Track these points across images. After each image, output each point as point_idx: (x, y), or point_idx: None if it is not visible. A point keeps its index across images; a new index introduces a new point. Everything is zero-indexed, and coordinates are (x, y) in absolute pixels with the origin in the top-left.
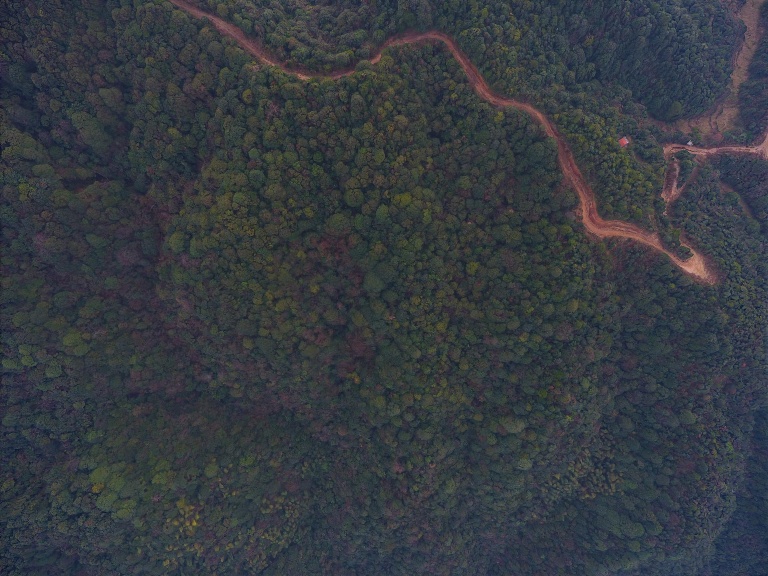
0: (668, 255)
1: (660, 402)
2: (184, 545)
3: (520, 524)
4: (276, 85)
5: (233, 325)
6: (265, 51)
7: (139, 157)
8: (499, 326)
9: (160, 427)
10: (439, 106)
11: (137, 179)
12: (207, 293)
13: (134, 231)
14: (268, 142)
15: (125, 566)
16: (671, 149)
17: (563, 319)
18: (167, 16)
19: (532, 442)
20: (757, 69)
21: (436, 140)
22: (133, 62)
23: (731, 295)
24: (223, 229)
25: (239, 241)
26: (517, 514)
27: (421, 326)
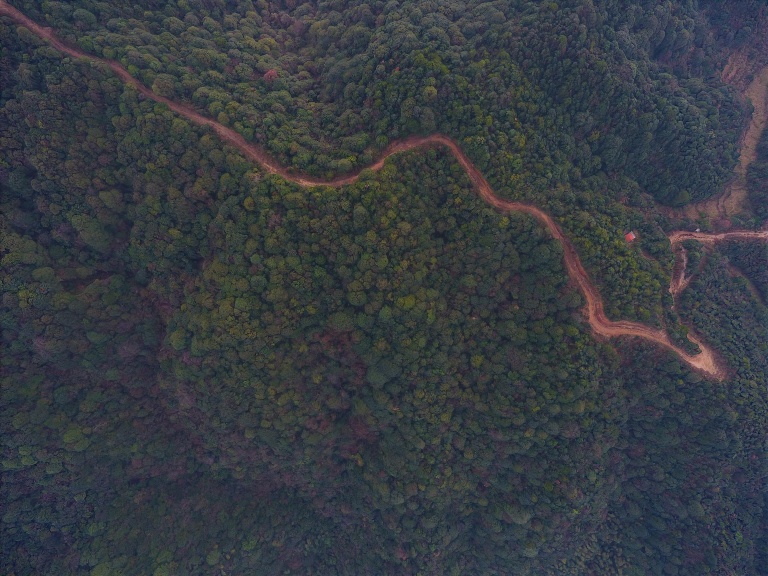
0: (676, 353)
1: (668, 491)
2: None
3: None
4: (278, 195)
5: (235, 418)
6: (267, 156)
7: (140, 253)
8: (504, 421)
9: (162, 514)
10: (443, 208)
11: (138, 272)
12: (209, 389)
13: (135, 324)
14: (270, 249)
15: None
16: (678, 237)
17: (569, 419)
18: (167, 125)
19: (538, 532)
20: (765, 150)
21: (440, 241)
22: (133, 166)
23: (740, 392)
24: (224, 333)
25: (241, 343)
26: None
27: (425, 418)
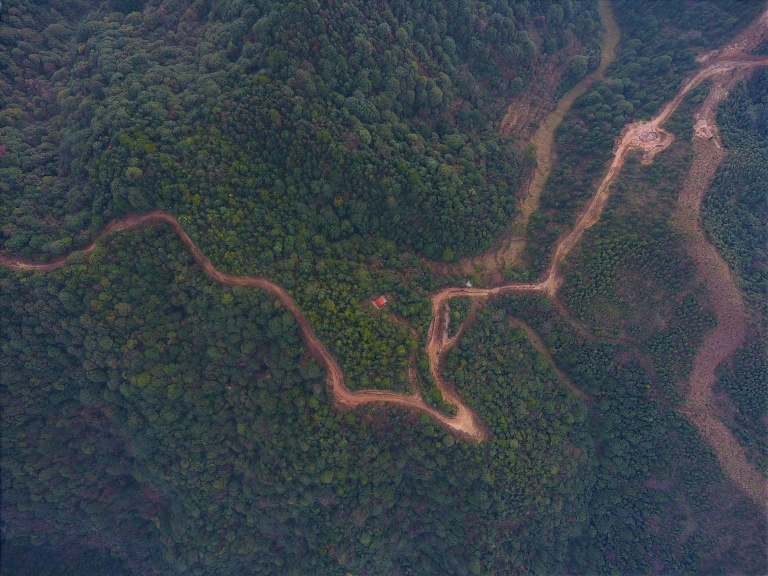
0: None
1: (453, 547)
2: None
3: None
4: None
5: (1, 494)
6: None
7: None
8: (267, 489)
9: None
10: (173, 284)
11: None
12: None
13: None
14: None
15: None
16: (448, 294)
17: (321, 488)
18: None
19: None
20: (545, 200)
21: (175, 316)
22: None
23: (497, 453)
24: None
25: None
26: None
27: (196, 486)
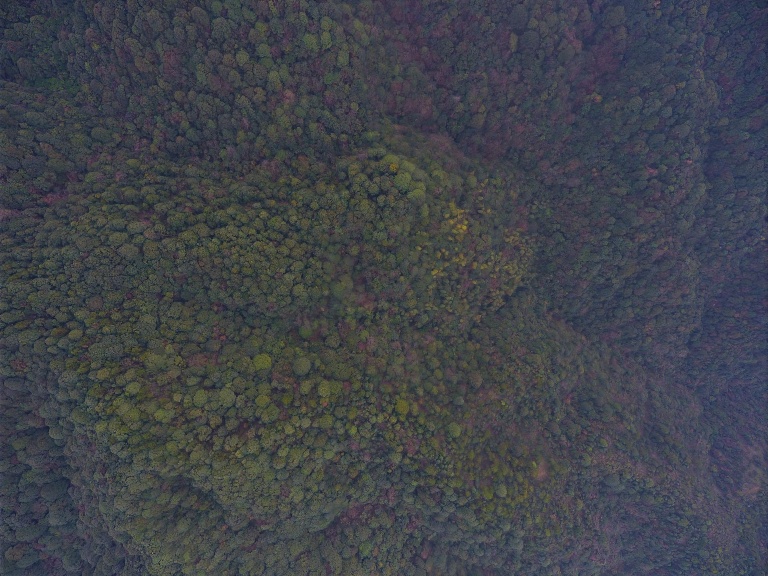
0: None
1: None
2: (455, 249)
3: (748, 250)
4: None
5: (507, 14)
6: None
7: None
8: None
9: (421, 140)
10: None
11: None
12: None
13: None
14: None
15: (408, 262)
16: None
17: None
18: None
19: None
20: None
21: None
22: None
23: None
24: None
25: None
26: (747, 237)
27: (687, 8)
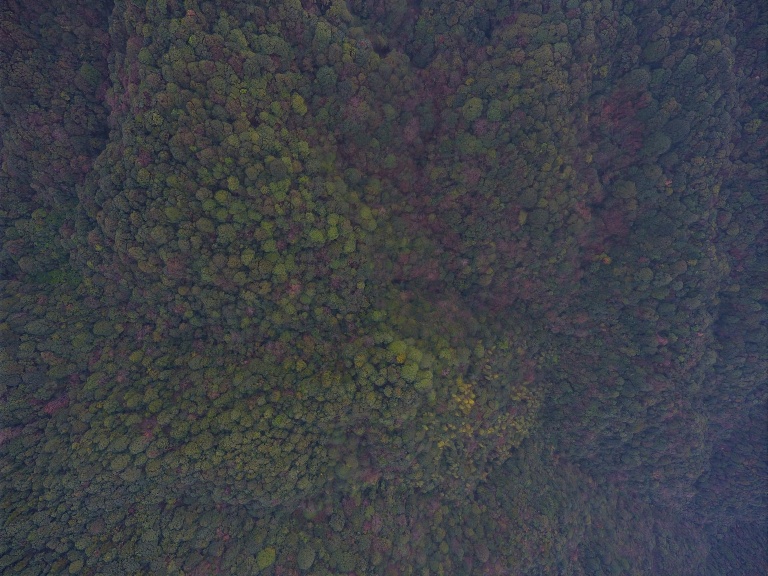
0: None
1: None
2: (462, 423)
3: (757, 402)
4: None
5: (516, 196)
6: None
7: (429, 26)
8: None
9: (428, 310)
10: None
11: (419, 52)
12: (499, 160)
13: None
14: None
15: (414, 443)
16: None
17: None
18: None
19: None
20: None
21: None
22: None
23: None
24: (540, 83)
25: (550, 97)
26: (757, 391)
27: (699, 189)
